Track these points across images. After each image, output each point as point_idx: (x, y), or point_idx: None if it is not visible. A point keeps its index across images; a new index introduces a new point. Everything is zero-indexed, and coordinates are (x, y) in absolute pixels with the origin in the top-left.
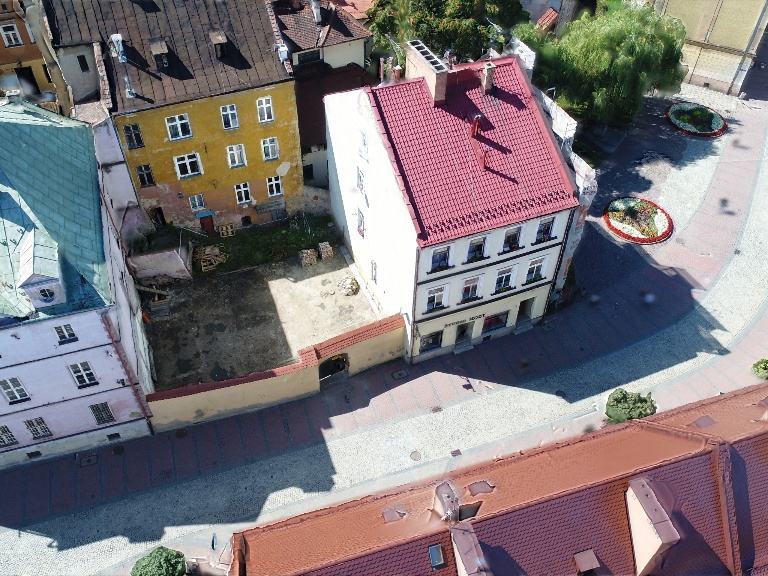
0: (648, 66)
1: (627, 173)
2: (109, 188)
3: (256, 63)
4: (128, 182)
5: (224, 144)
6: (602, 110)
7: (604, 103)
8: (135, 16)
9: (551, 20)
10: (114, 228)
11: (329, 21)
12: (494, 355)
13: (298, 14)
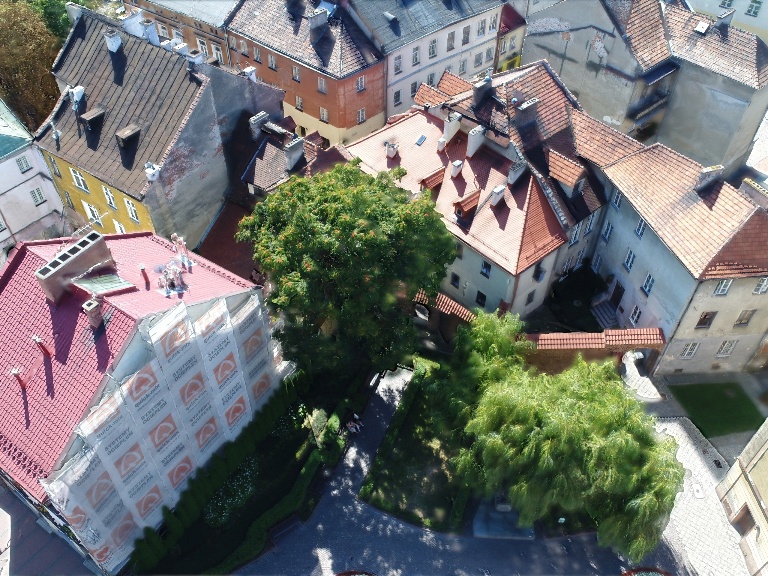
0: (550, 484)
1: (450, 571)
2: (46, 191)
3: (137, 169)
4: (57, 196)
5: (111, 215)
6: (464, 477)
7: (465, 471)
8: (106, 80)
9: (638, 341)
10: (3, 219)
11: (294, 174)
12: (49, 557)
13: (283, 151)
